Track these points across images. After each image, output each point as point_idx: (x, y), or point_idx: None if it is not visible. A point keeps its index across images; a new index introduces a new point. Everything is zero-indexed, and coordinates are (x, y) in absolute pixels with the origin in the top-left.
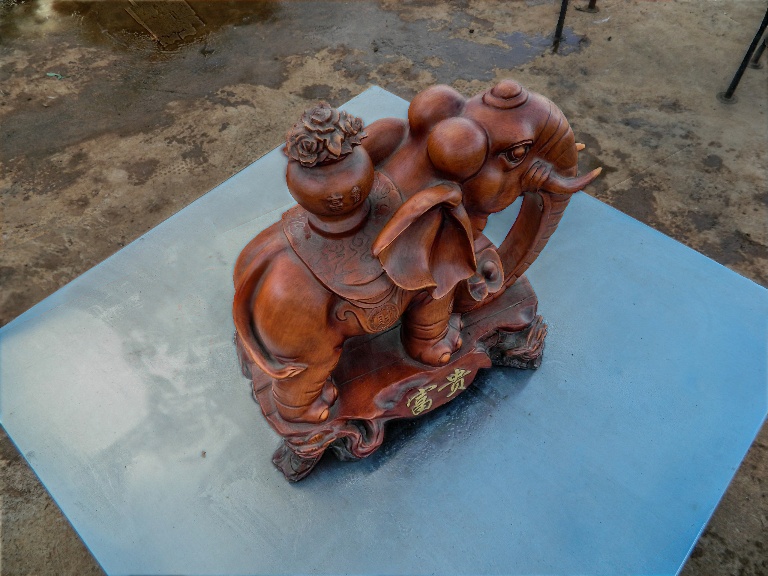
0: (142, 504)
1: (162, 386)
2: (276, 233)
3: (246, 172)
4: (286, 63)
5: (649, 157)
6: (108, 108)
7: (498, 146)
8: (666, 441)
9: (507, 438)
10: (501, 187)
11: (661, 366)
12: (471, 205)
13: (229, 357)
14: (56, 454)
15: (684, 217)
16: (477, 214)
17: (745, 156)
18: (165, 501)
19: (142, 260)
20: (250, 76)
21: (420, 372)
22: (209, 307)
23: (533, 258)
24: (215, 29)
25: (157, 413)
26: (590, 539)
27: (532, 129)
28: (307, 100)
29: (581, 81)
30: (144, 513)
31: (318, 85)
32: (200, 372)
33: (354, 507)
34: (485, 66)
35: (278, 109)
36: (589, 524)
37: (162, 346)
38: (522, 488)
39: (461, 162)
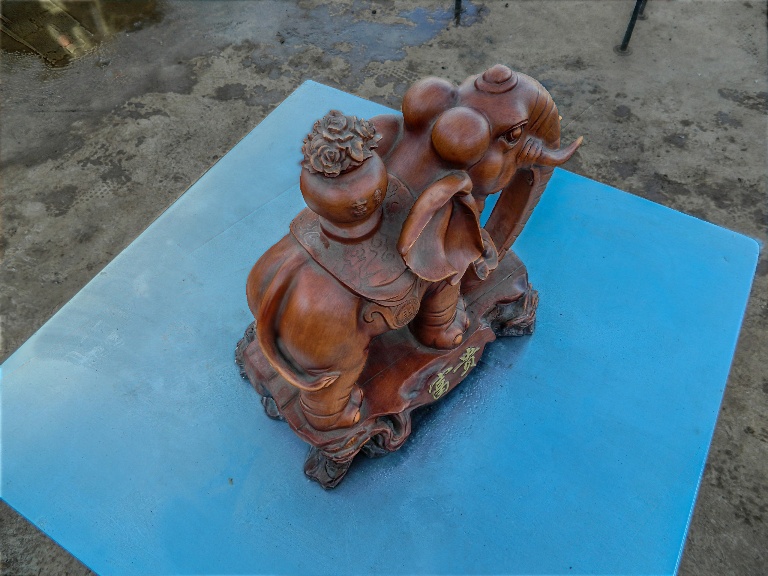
0: (179, 545)
1: (168, 422)
2: (292, 247)
3: (198, 187)
4: (191, 66)
5: (565, 115)
6: (5, 138)
7: (498, 130)
8: (660, 378)
9: (521, 404)
10: (502, 168)
11: (640, 310)
12: (474, 190)
13: (231, 379)
14: (71, 515)
15: (608, 167)
16: (478, 197)
17: (649, 103)
18: (203, 537)
19: (110, 295)
20: (156, 84)
21: (436, 358)
22: (196, 332)
23: (520, 230)
24: (106, 38)
25: (170, 450)
26: (616, 480)
27: (526, 109)
28: (223, 102)
29: (489, 50)
30: (184, 553)
31: (231, 85)
32: (205, 399)
33: (395, 500)
34: (395, 46)
35: (194, 115)
36: (612, 467)
37: (157, 381)
38: (546, 447)
39: (471, 150)
